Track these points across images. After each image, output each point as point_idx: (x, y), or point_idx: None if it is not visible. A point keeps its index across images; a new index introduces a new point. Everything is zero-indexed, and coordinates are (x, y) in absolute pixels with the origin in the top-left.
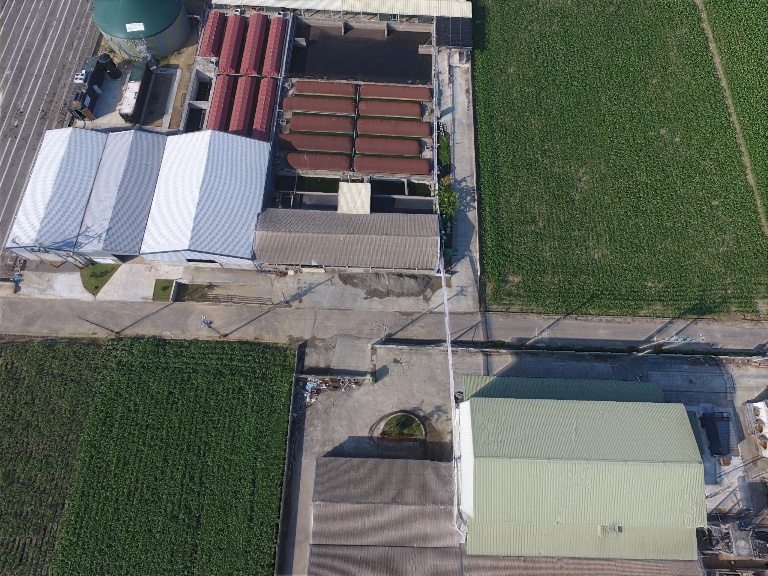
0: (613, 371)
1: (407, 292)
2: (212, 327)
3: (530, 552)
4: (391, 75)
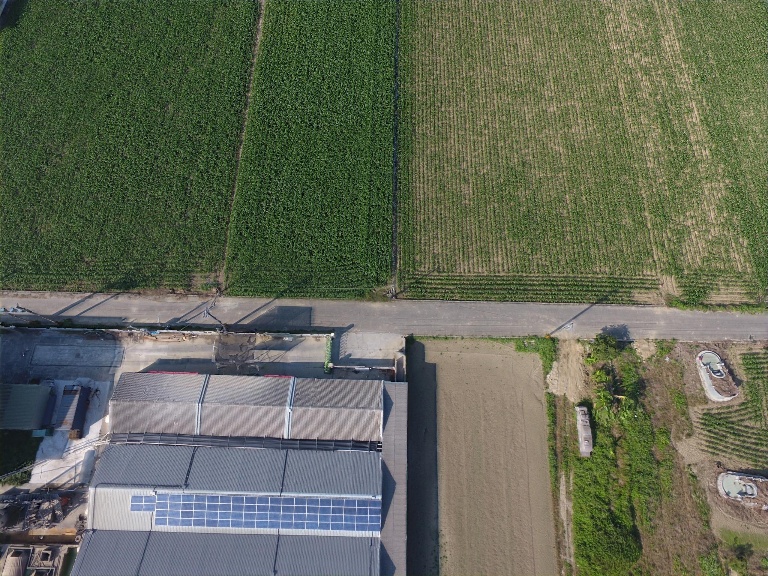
0: (1, 346)
1: None
2: None
3: None
4: None
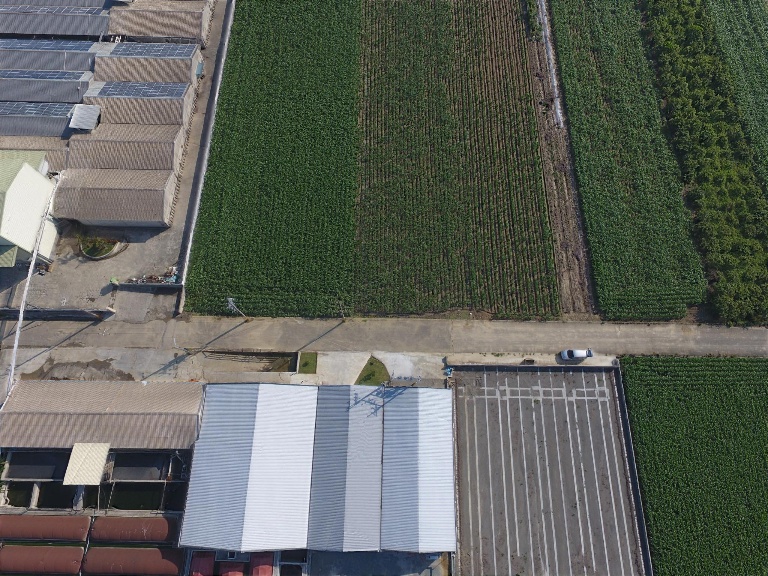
0: None
1: (68, 367)
2: (260, 329)
3: (1, 152)
4: None
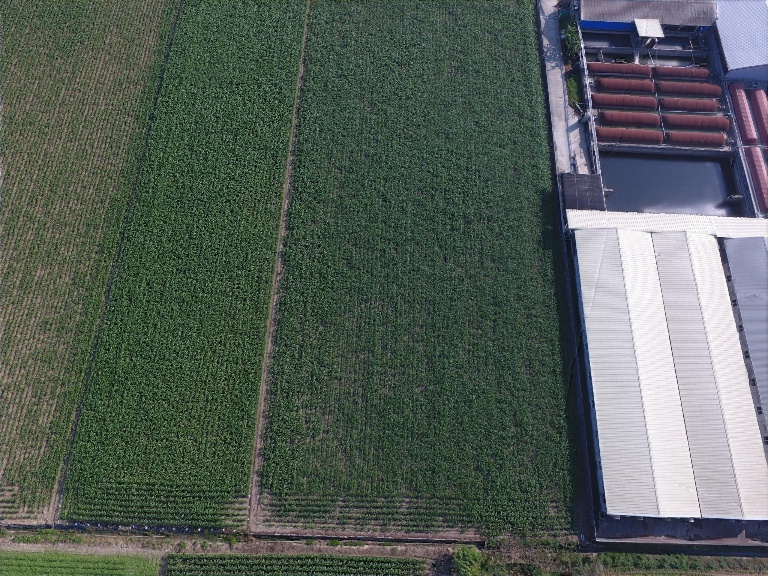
0: None
1: None
2: None
3: None
4: (631, 170)
